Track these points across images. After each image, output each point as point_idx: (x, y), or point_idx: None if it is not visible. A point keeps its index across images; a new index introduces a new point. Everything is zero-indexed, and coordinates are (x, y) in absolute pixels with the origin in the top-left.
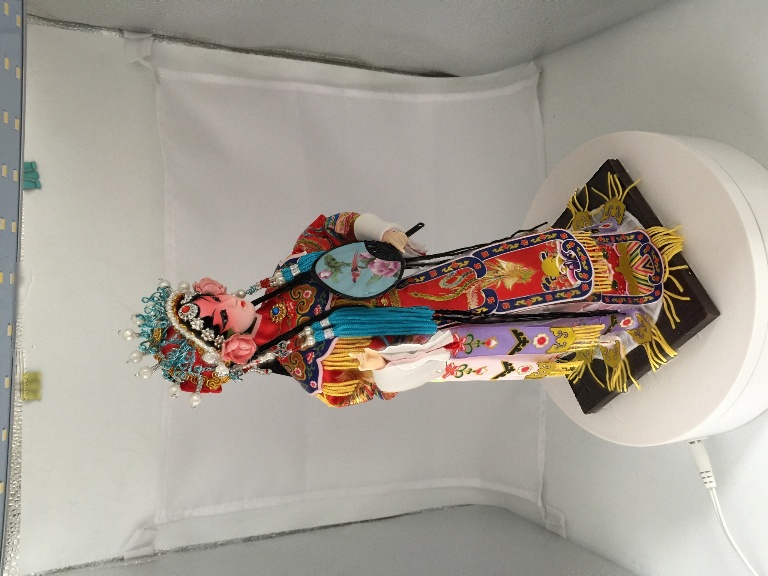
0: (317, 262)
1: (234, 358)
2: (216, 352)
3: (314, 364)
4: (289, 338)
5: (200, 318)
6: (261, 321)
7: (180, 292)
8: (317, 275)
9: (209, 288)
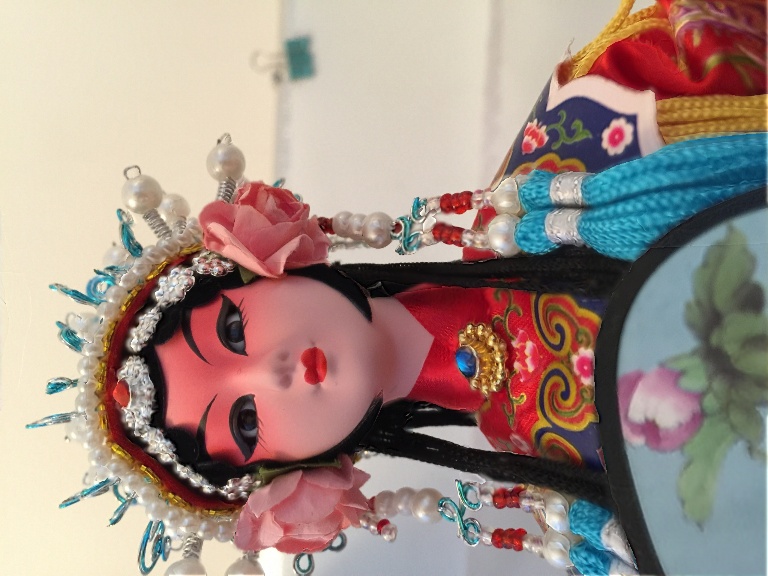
0: (650, 275)
1: (287, 540)
2: (230, 521)
3: (577, 572)
4: (496, 477)
5: (164, 430)
6: (425, 362)
7: (165, 250)
8: (614, 385)
9: (236, 255)
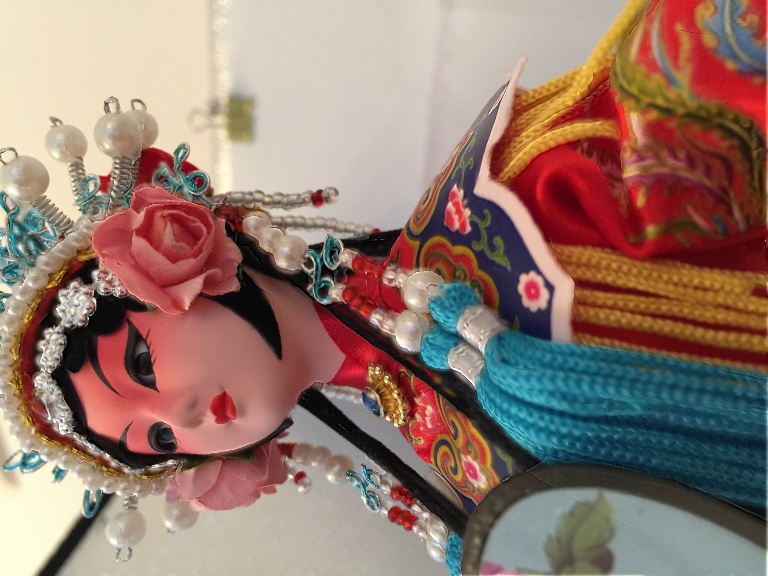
0: (523, 499)
1: None
2: (161, 480)
3: None
4: None
5: (87, 437)
6: (337, 373)
7: (60, 255)
8: (477, 565)
9: None
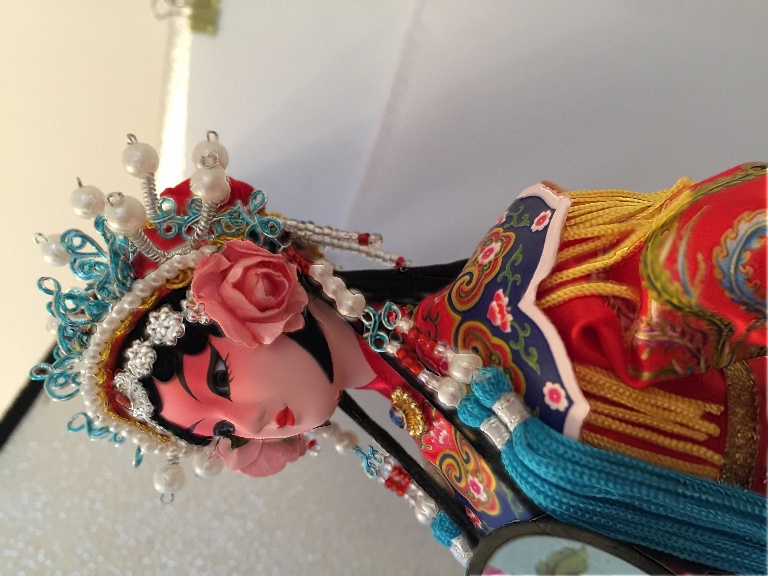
0: (528, 537)
1: None
2: None
3: None
4: None
5: (158, 422)
6: (366, 385)
7: (152, 283)
8: (483, 566)
9: None
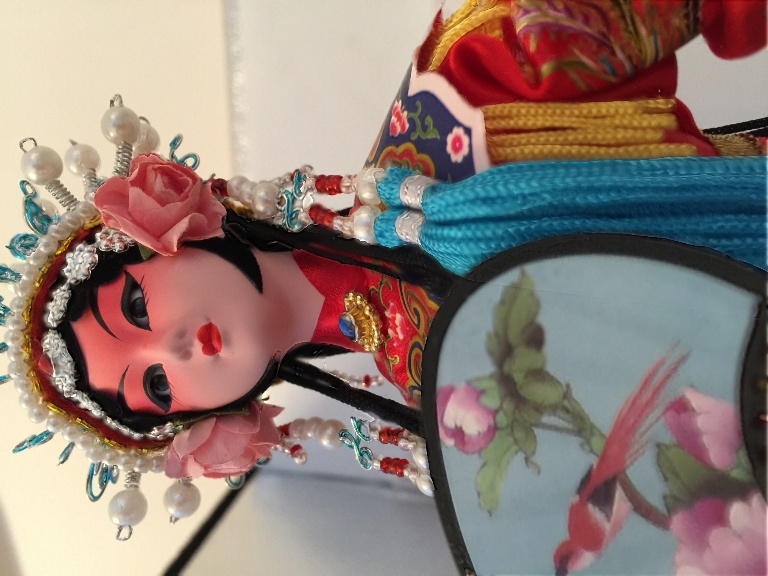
0: (461, 305)
1: None
2: (162, 456)
3: None
4: (382, 418)
5: (88, 394)
6: (319, 318)
7: (69, 224)
8: (434, 394)
9: (132, 236)
